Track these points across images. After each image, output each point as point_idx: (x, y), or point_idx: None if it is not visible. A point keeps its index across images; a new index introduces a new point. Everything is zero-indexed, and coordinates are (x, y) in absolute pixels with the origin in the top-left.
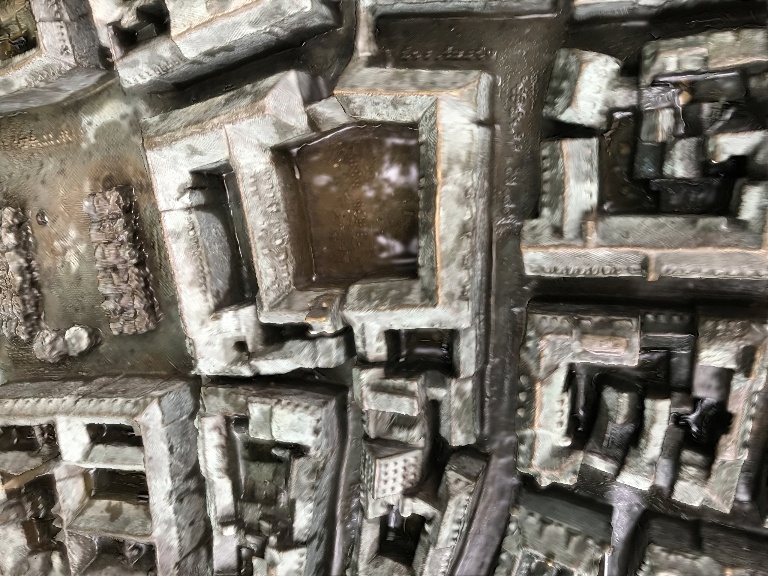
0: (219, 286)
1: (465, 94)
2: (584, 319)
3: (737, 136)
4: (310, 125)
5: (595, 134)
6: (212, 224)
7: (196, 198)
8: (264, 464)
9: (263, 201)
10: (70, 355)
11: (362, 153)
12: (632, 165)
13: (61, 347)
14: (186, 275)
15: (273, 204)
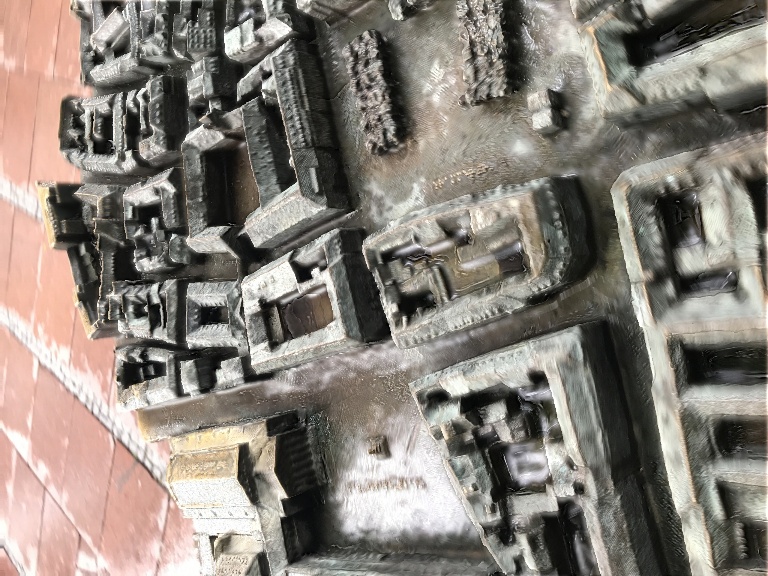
0: None
1: None
2: None
3: None
4: None
5: None
6: None
7: None
8: None
9: None
10: None
11: None
12: None
13: None
14: None
15: None
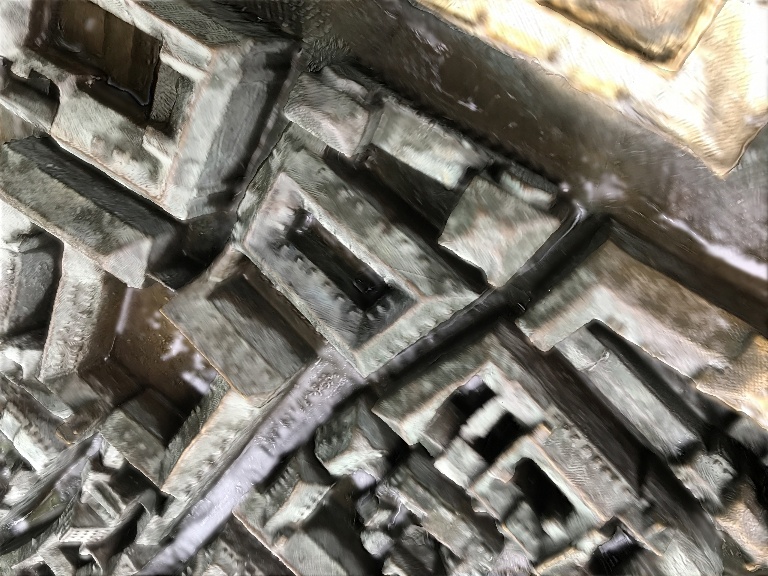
0: (22, 312)
1: (253, 400)
2: (248, 571)
3: (403, 574)
4: (145, 286)
5: (335, 480)
6: (39, 262)
7: (28, 245)
8: (6, 439)
9: (77, 307)
10: None
11: None
12: (357, 498)
13: None
14: None
15: (85, 313)
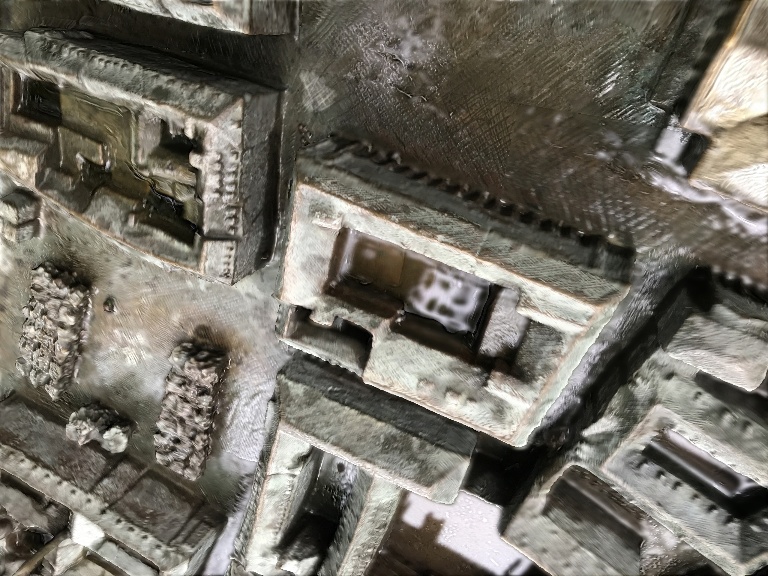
0: None
1: None
2: None
3: None
4: None
5: None
6: (307, 471)
7: None
8: None
9: (375, 524)
10: (102, 447)
11: (482, 500)
12: None
13: (95, 436)
14: (266, 521)
15: (382, 527)
